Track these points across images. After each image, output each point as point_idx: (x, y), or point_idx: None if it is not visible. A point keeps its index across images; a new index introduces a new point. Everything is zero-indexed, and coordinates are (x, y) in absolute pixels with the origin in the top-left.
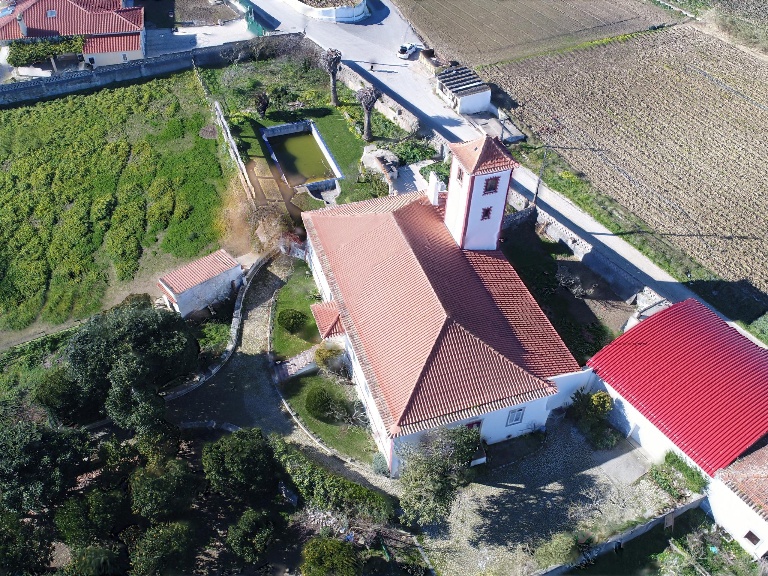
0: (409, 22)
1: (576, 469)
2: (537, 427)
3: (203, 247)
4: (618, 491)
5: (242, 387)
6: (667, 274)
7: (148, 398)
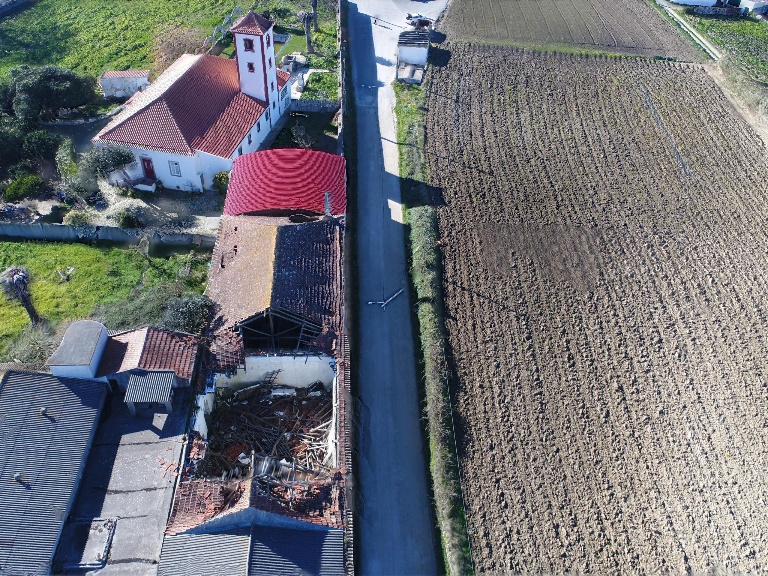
0: (449, 6)
1: (194, 213)
2: (194, 187)
3: (157, 75)
4: (201, 228)
5: (95, 131)
6: (398, 171)
7: (27, 100)
